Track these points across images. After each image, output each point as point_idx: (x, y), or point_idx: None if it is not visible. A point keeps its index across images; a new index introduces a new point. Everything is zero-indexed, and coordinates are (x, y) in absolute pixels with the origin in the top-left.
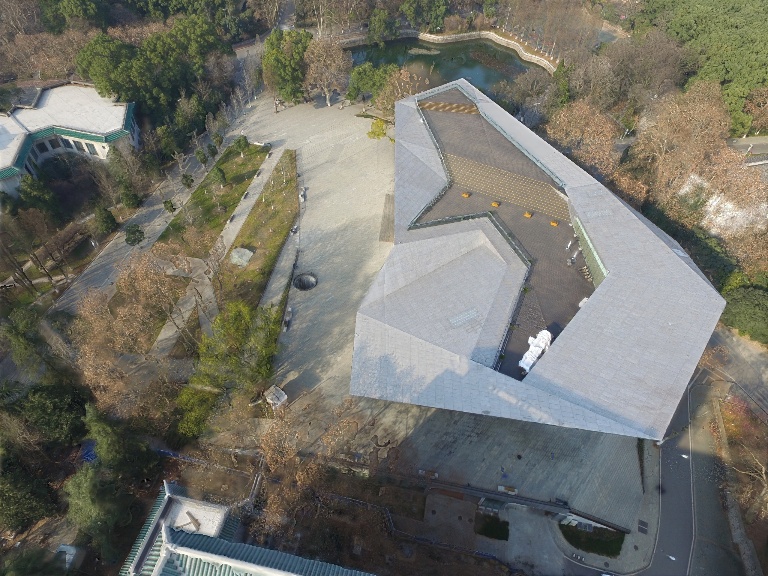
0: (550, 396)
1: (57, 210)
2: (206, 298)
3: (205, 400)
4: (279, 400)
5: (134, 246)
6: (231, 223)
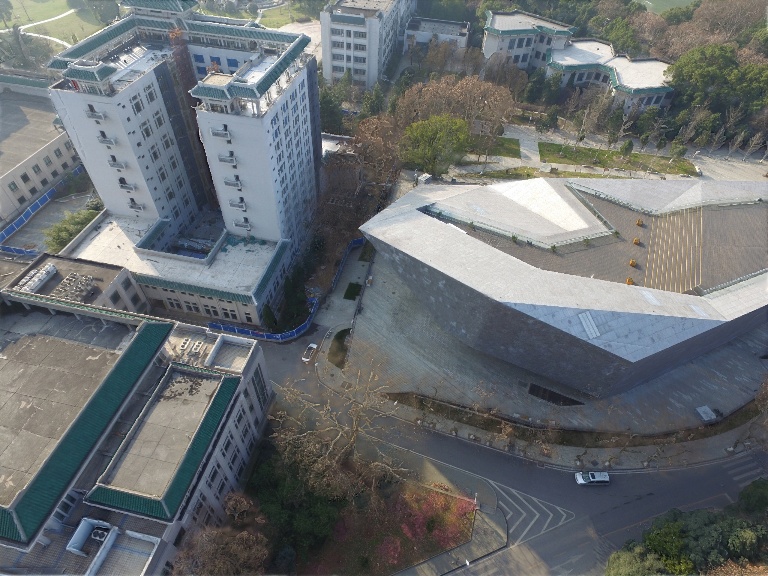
0: (401, 212)
1: (551, 100)
2: (505, 166)
3: (411, 140)
4: (422, 178)
5: (541, 136)
6: (583, 167)
